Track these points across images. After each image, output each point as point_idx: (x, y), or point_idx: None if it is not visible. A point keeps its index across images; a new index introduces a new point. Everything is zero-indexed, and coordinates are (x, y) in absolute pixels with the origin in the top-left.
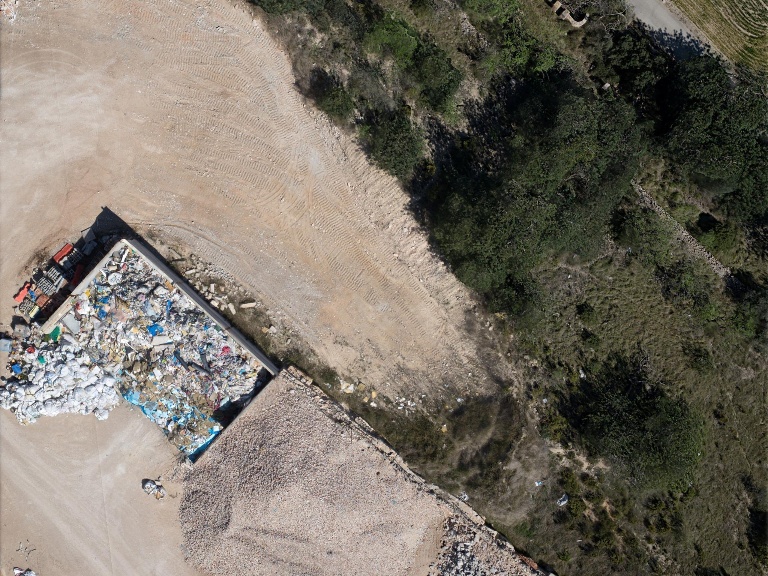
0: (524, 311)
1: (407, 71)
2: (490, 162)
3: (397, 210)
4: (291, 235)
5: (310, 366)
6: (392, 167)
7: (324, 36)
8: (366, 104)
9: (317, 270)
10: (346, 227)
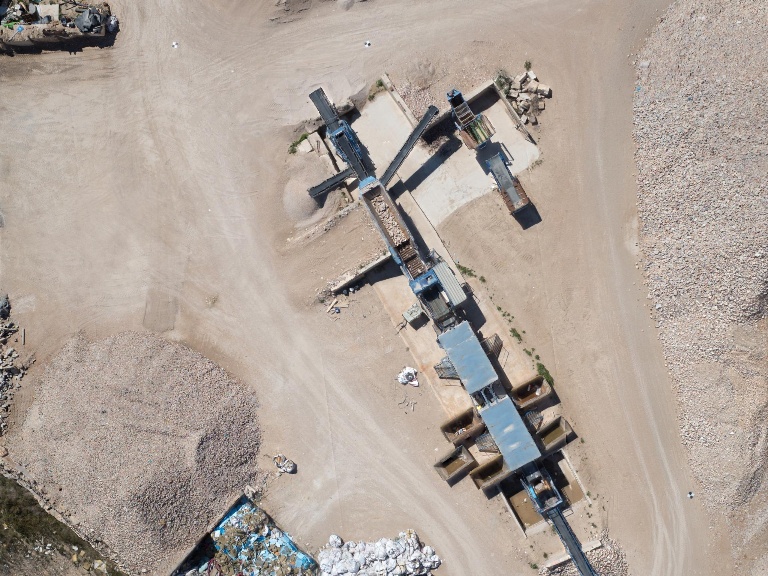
0: None
1: None
2: None
3: None
4: None
5: None
6: None
7: None
8: None
9: None
10: None
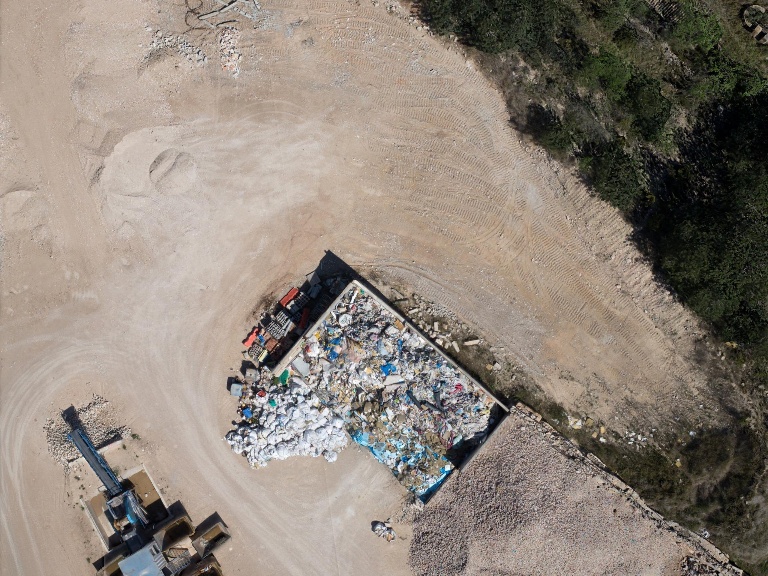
0: (762, 338)
1: (618, 102)
2: (705, 189)
3: (620, 241)
4: (511, 271)
5: (536, 402)
6: (615, 198)
7: (537, 72)
8: (584, 137)
9: (539, 305)
10: (567, 260)
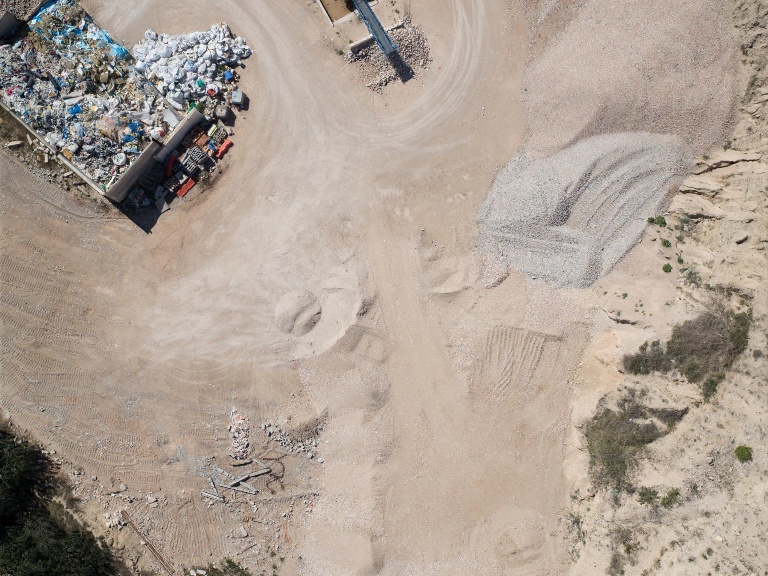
0: None
1: None
2: None
3: None
4: None
5: None
6: None
7: None
8: None
9: None
10: None
